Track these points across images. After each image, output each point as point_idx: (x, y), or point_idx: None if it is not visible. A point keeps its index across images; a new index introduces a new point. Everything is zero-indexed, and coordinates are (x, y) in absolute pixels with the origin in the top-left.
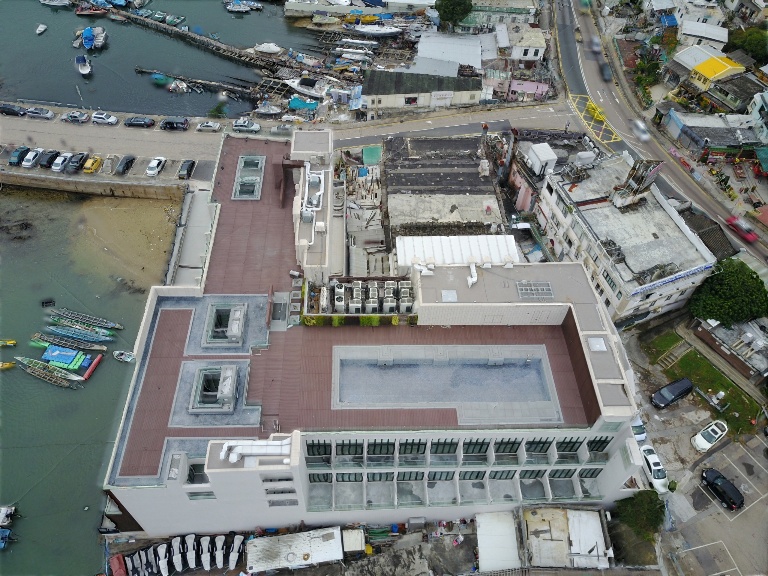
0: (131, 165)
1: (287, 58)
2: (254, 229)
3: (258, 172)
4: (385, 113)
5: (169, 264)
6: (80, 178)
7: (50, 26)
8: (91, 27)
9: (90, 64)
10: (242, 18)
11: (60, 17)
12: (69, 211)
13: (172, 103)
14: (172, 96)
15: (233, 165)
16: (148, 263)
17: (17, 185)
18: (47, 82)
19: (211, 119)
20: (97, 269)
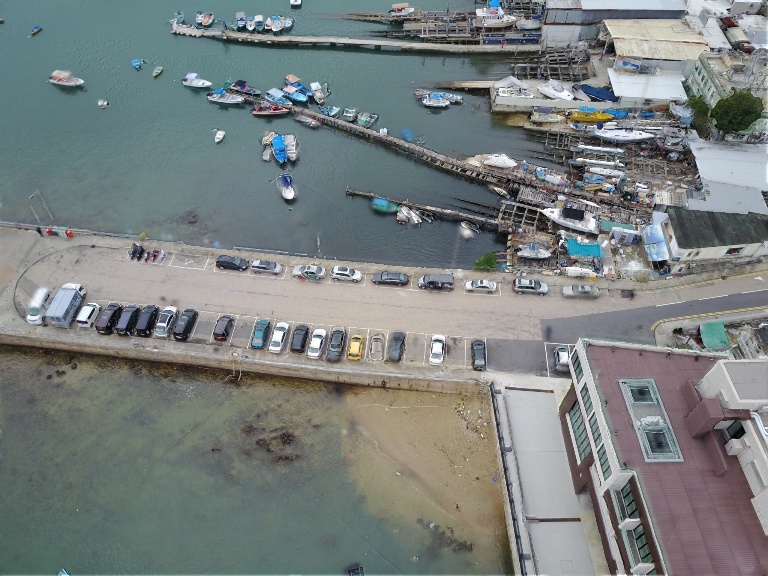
0: (404, 347)
1: (523, 173)
2: (701, 518)
3: (655, 408)
4: (698, 265)
5: (516, 519)
6: (346, 368)
7: (227, 131)
8: (275, 132)
9: (290, 184)
10: (440, 113)
11: (231, 116)
12: (334, 412)
13: (401, 237)
14: (402, 229)
15: (616, 396)
16: (461, 498)
17: (259, 373)
18: (246, 211)
19: (478, 273)
20: (398, 508)
